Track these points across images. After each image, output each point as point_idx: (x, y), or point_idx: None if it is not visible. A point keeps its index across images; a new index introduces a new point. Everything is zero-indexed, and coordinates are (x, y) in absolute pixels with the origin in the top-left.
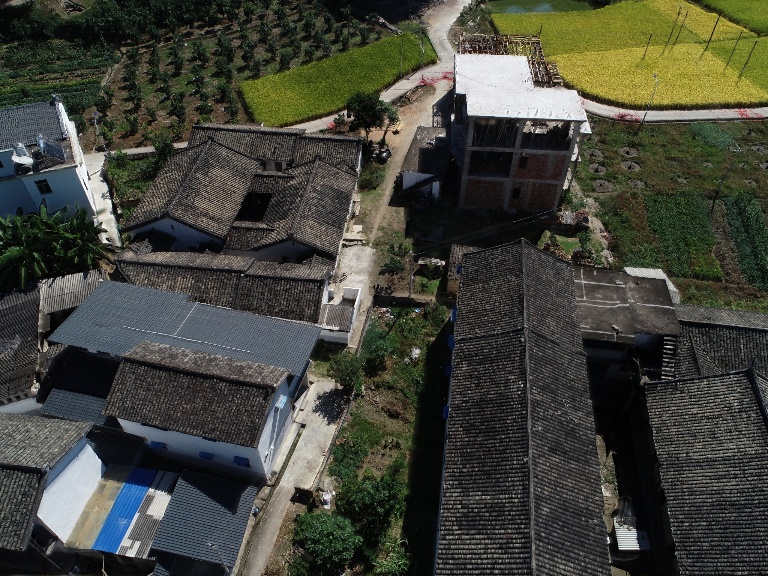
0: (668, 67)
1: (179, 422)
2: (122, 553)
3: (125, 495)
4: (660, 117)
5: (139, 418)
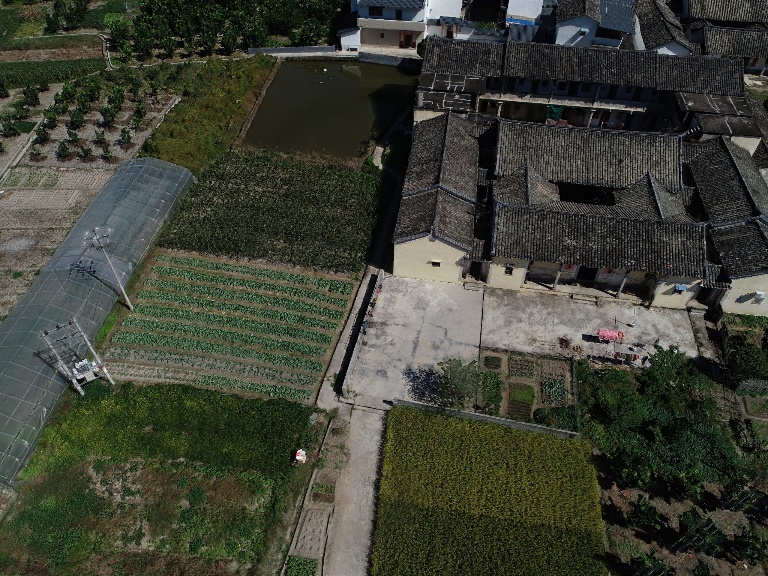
0: None
1: (561, 7)
2: (506, 22)
3: (530, 22)
4: None
5: (560, 1)
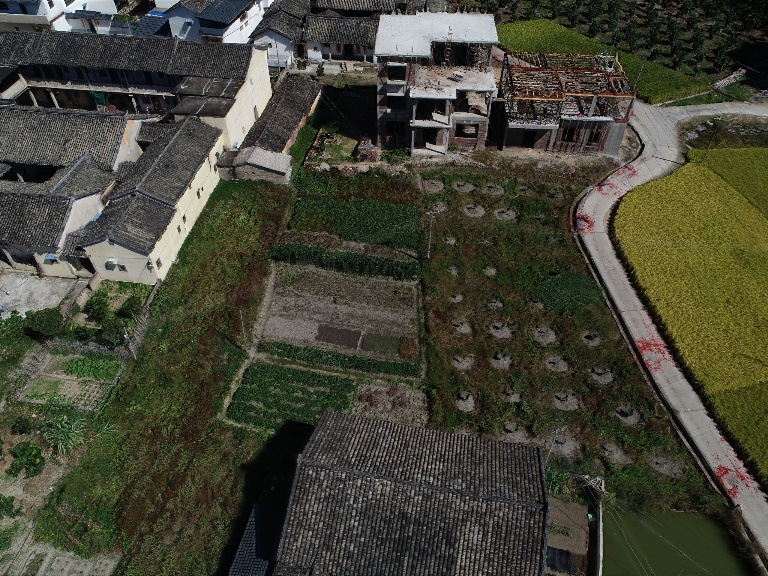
0: (763, 285)
1: None
2: None
3: None
4: (597, 251)
5: None
